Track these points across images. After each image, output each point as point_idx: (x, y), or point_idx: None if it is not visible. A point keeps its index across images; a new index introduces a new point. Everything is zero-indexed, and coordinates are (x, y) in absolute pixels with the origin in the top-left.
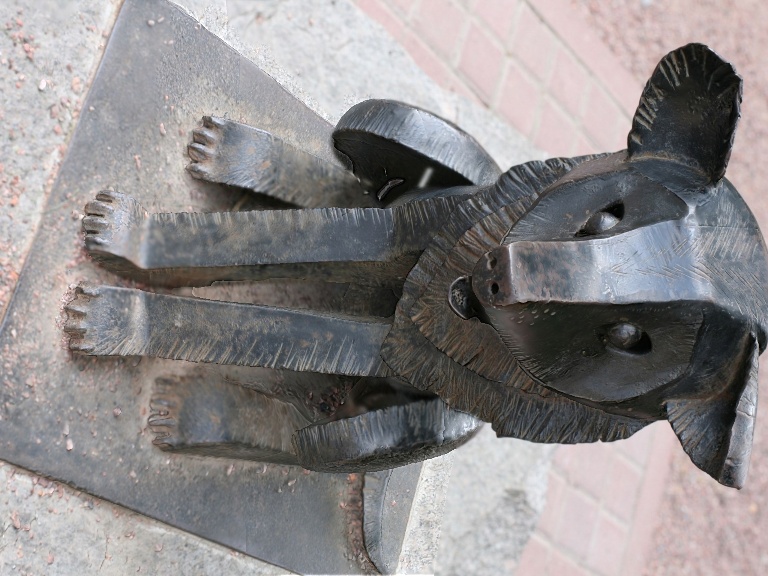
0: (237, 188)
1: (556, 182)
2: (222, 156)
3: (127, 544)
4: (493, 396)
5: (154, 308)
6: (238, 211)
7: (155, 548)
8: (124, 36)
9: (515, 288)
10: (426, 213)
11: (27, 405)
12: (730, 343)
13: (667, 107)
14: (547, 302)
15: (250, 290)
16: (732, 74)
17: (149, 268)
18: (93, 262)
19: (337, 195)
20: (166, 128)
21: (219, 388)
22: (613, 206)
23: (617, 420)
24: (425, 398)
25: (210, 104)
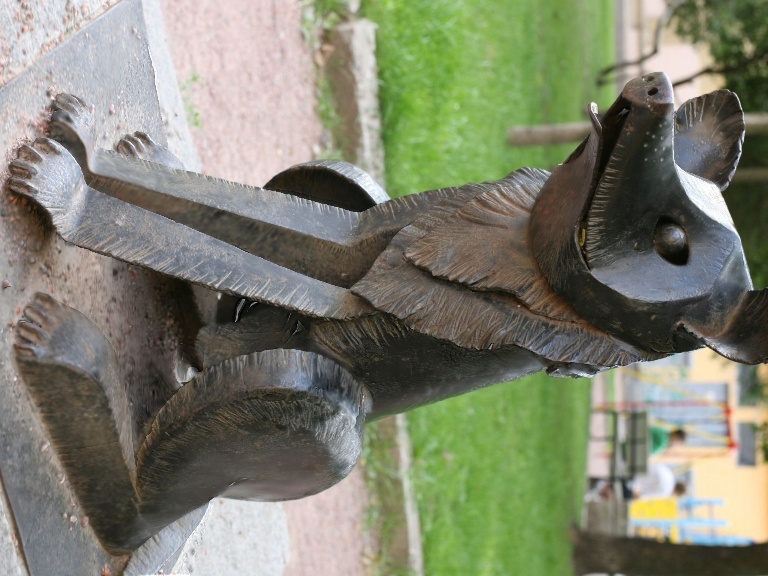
0: None
1: None
2: None
3: None
4: (494, 315)
5: (95, 203)
6: None
7: None
8: (119, 17)
9: None
10: (414, 202)
11: None
12: (736, 290)
13: (678, 141)
14: None
15: (108, 306)
16: (740, 122)
17: (97, 174)
18: None
19: None
20: None
21: (99, 331)
22: None
23: (620, 347)
24: (352, 375)
25: None
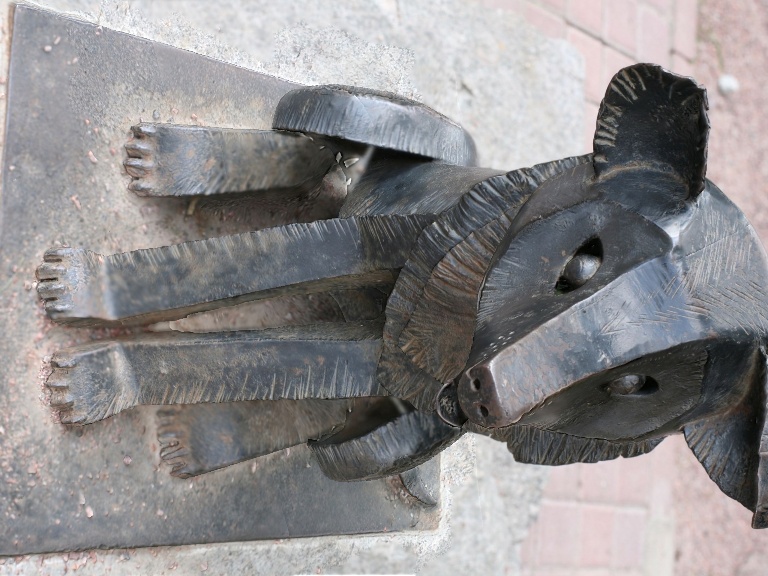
0: (187, 196)
1: (523, 215)
2: (162, 166)
3: (173, 575)
4: None
5: (135, 359)
6: (194, 241)
7: (201, 569)
8: (23, 75)
9: (505, 410)
10: (391, 230)
11: (36, 492)
12: (740, 363)
13: (628, 120)
14: (542, 403)
15: None
16: (694, 87)
17: (119, 318)
18: (60, 325)
19: (292, 162)
20: (96, 154)
21: (222, 407)
22: (590, 241)
23: None
24: None
25: (135, 108)
